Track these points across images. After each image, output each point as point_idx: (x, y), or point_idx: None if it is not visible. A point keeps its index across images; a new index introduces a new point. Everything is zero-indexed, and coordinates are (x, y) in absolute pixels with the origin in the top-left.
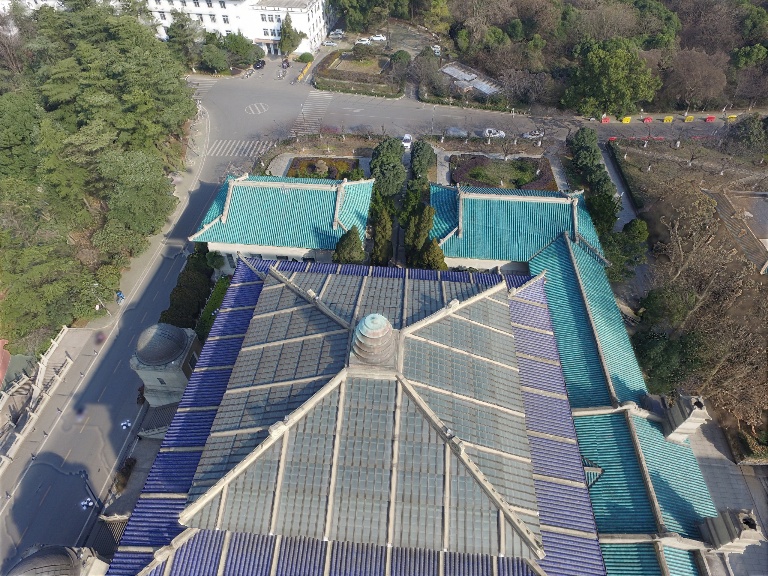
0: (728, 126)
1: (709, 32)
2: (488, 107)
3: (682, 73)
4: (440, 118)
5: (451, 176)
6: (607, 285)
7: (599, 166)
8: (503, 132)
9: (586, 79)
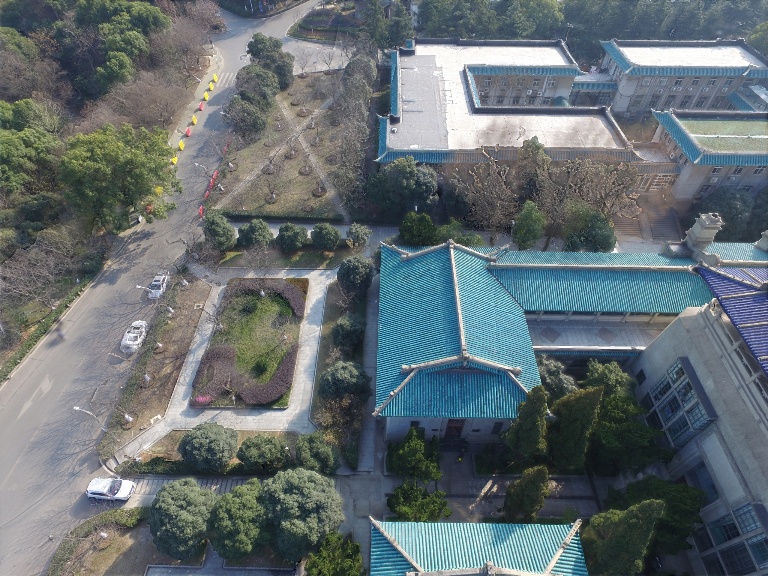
0: (238, 121)
1: (14, 74)
2: (37, 336)
3: (155, 111)
4: (28, 422)
5: (253, 406)
6: (539, 253)
7: (289, 228)
8: (137, 322)
9: (106, 190)
